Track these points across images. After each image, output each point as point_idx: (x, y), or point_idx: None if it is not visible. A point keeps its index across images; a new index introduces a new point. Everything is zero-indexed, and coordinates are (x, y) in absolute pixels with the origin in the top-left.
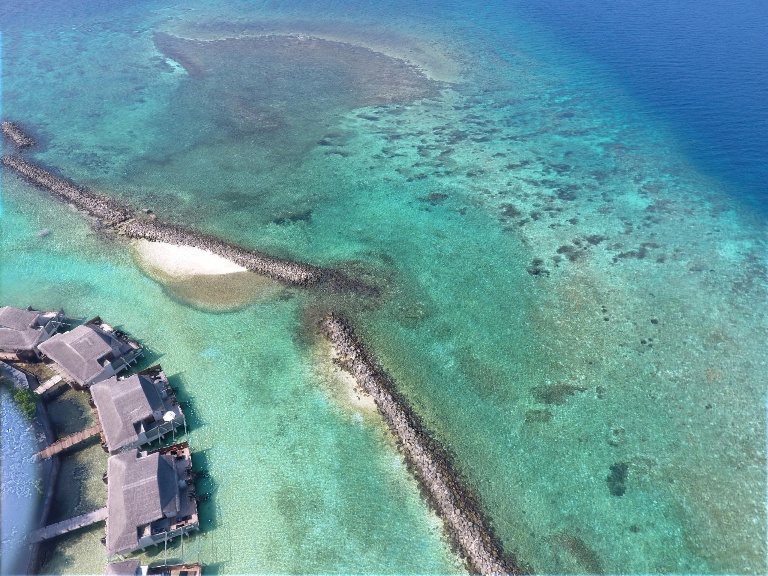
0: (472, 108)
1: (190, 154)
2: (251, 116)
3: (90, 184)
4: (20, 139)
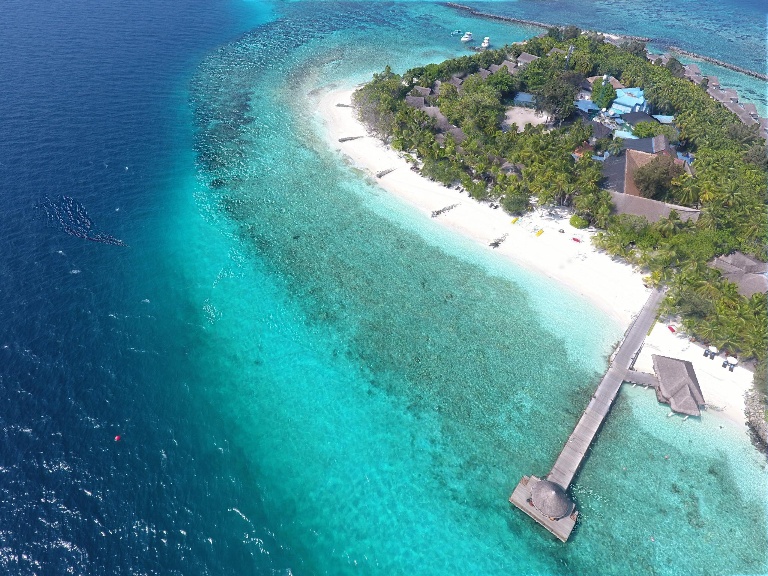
0: (653, 2)
1: (545, 13)
2: (551, 3)
3: None
4: (468, 7)
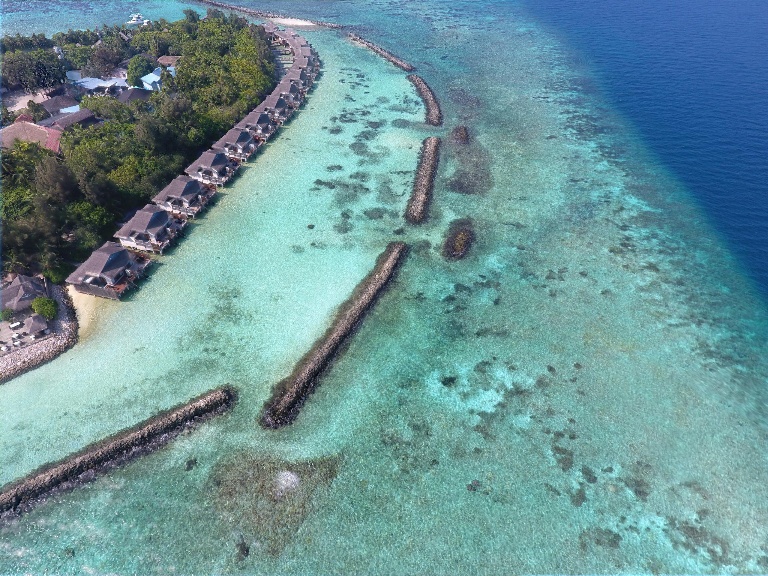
0: None
1: (279, 1)
2: None
3: (239, 6)
4: None
